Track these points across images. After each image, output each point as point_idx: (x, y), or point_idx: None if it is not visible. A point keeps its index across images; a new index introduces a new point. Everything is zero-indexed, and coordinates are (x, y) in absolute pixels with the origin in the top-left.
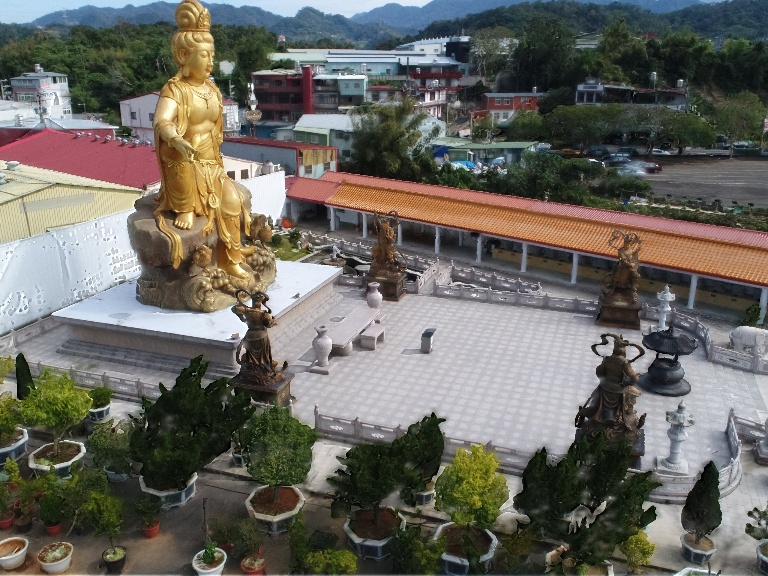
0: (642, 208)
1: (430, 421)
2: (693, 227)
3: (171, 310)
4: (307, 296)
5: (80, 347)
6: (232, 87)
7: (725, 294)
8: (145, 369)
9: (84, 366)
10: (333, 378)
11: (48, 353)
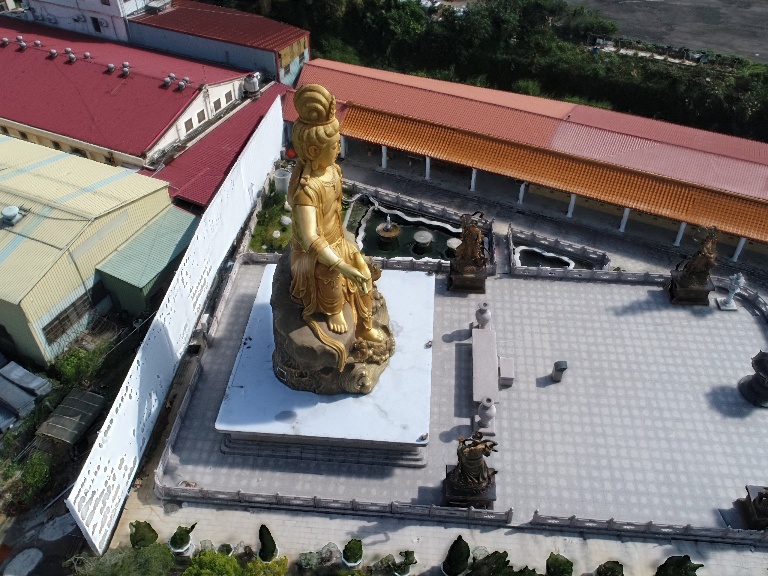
0: (612, 58)
1: (692, 568)
2: (724, 161)
3: (329, 396)
4: None
5: (248, 447)
6: None
7: (762, 243)
8: (328, 463)
9: (267, 471)
10: (502, 440)
11: (215, 456)
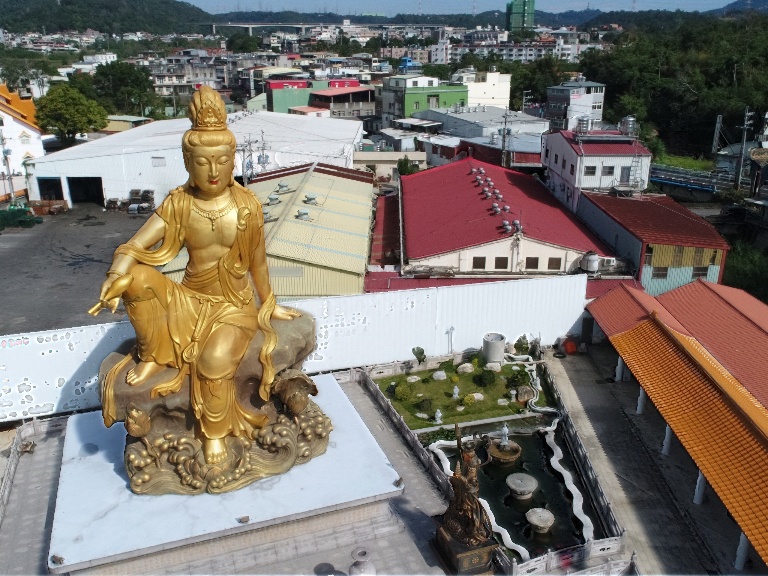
0: None
1: None
2: None
3: None
4: (271, 522)
5: None
6: (750, 114)
7: None
8: None
9: (50, 488)
10: None
11: None
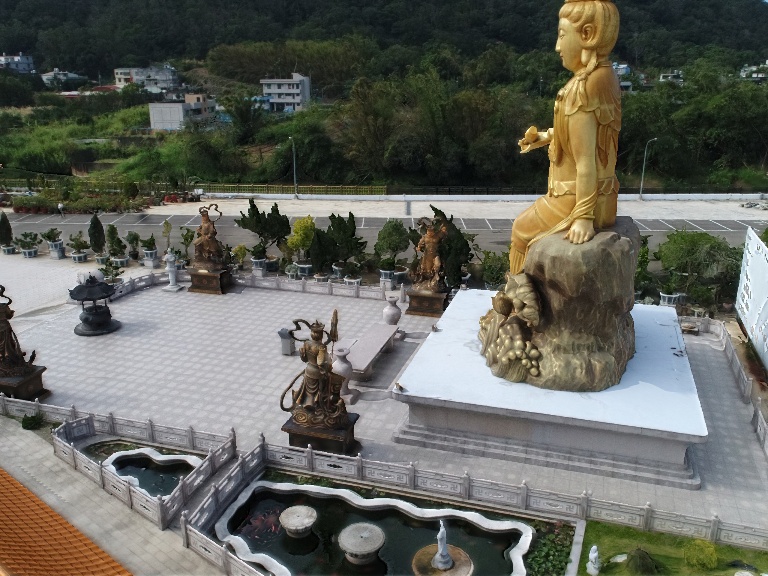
0: None
1: None
2: None
3: None
4: None
5: None
6: None
7: None
8: None
9: None
10: None
11: None
